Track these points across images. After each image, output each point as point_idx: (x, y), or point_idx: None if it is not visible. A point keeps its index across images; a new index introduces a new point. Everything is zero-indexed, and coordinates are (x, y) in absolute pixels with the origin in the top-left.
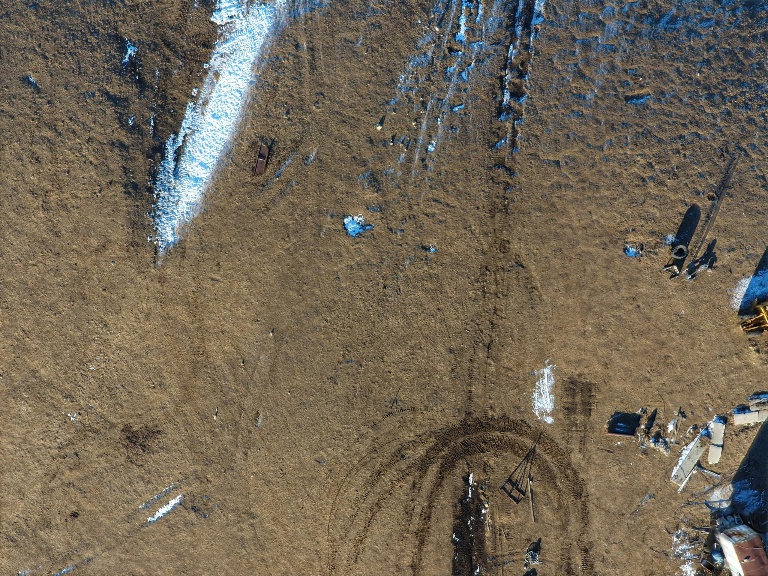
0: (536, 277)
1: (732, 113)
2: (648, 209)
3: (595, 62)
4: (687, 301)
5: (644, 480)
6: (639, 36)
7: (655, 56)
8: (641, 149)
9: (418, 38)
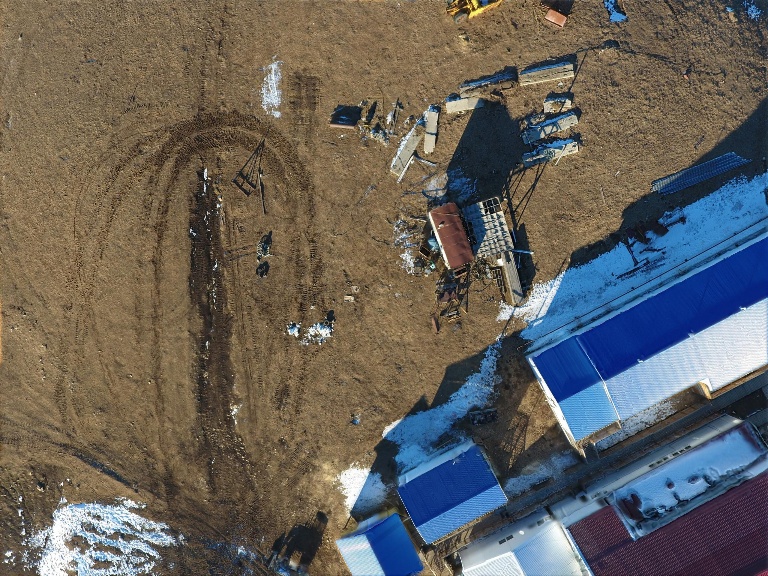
0: None
1: None
2: None
3: None
4: None
5: (366, 172)
6: None
7: None
8: None
9: None
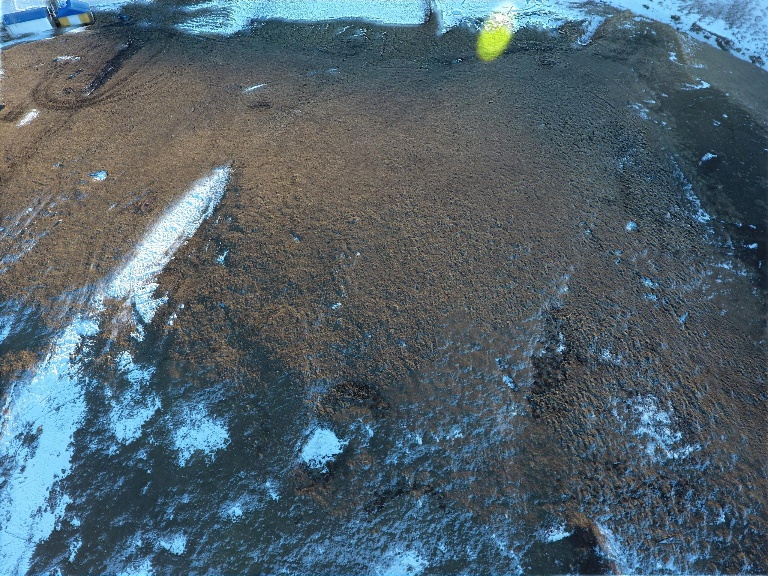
0: (2, 154)
1: None
2: None
3: None
4: None
5: (0, 94)
6: None
7: None
8: None
9: (5, 273)
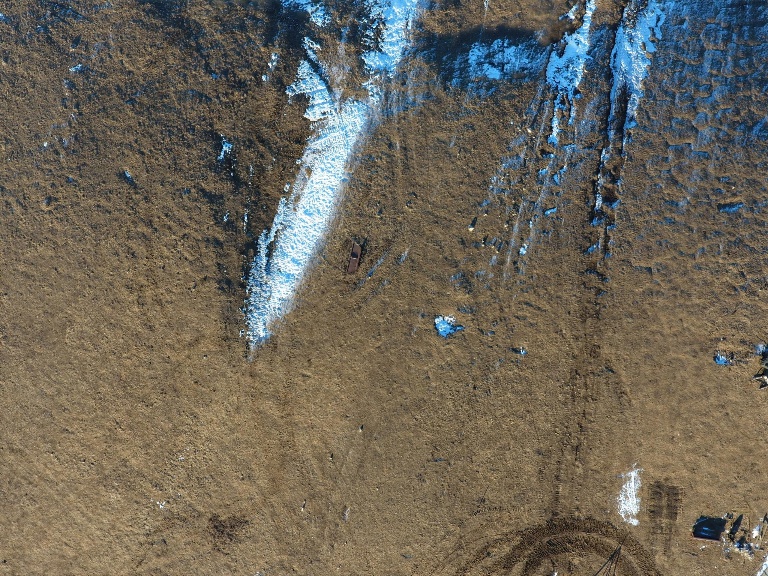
0: (626, 382)
1: None
2: (739, 318)
3: (688, 169)
4: None
5: None
6: (732, 144)
7: (748, 165)
8: (733, 258)
9: (510, 139)
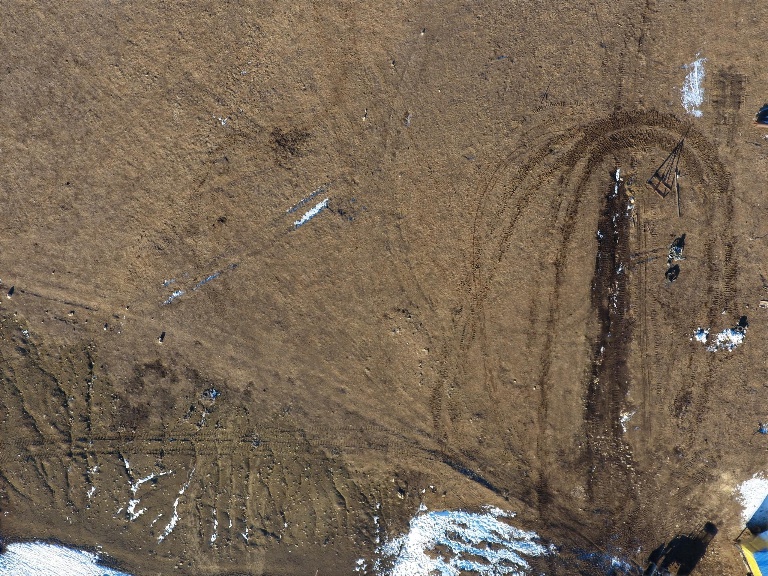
0: None
1: None
2: None
3: None
4: None
5: None
6: None
7: None
8: None
9: None
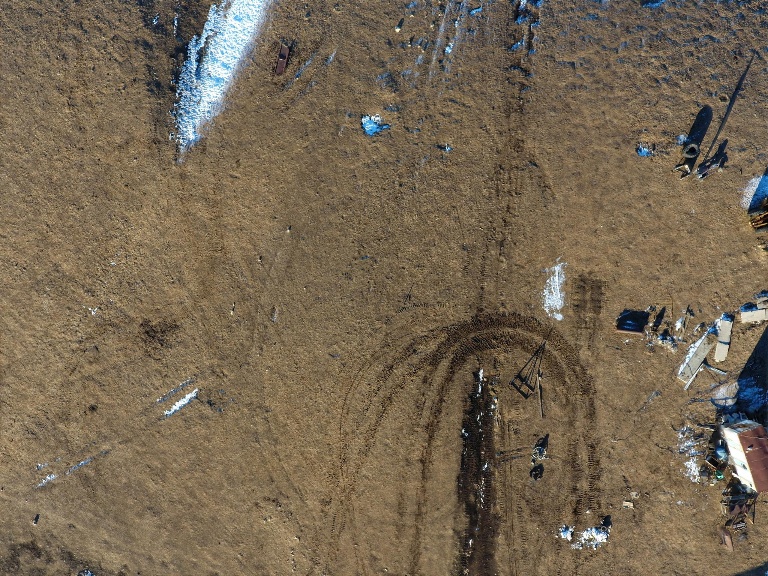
0: (549, 176)
1: (746, 17)
2: (661, 110)
3: None
4: (697, 200)
5: (651, 377)
6: None
7: None
8: (655, 51)
9: None
